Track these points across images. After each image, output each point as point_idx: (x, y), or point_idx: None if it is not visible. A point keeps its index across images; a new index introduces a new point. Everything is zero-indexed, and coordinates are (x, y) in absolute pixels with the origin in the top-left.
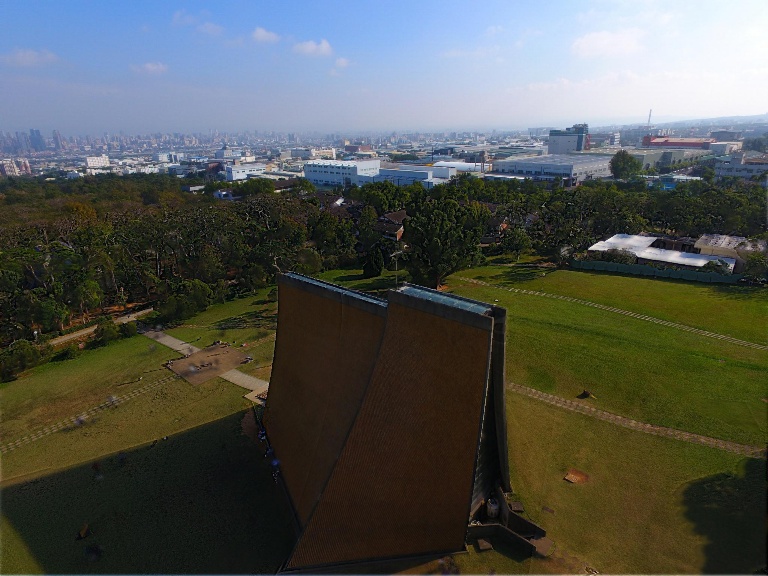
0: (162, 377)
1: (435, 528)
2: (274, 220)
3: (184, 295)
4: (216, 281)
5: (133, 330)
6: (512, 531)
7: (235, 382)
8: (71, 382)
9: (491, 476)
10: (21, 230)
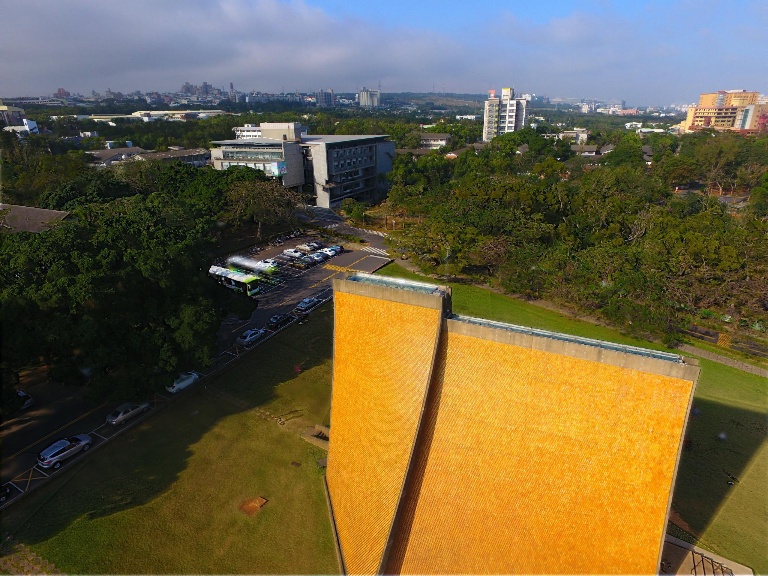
0: None
1: None
2: None
3: None
4: None
5: None
6: None
7: None
8: None
9: None
10: None
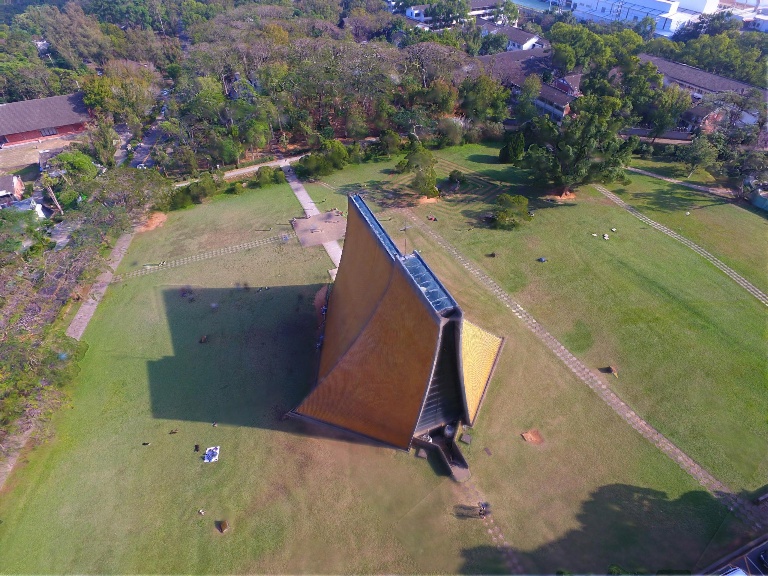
0: (285, 232)
1: (390, 430)
2: (431, 77)
3: (323, 155)
4: (359, 139)
5: (282, 178)
6: (444, 455)
7: (330, 254)
8: (230, 217)
9: (455, 411)
10: (227, 54)
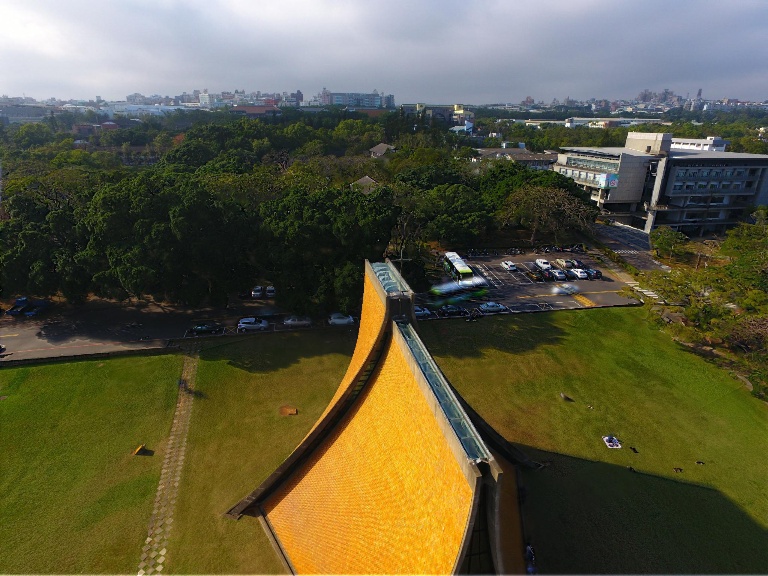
0: None
1: None
2: None
3: None
4: None
5: None
6: None
7: None
8: None
9: None
10: None
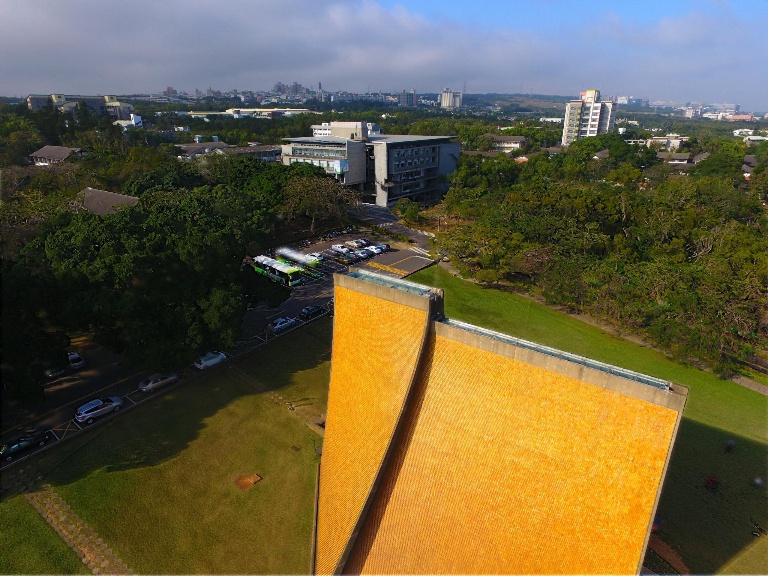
0: None
1: None
2: None
3: None
4: None
5: None
6: None
7: None
8: None
9: None
10: None
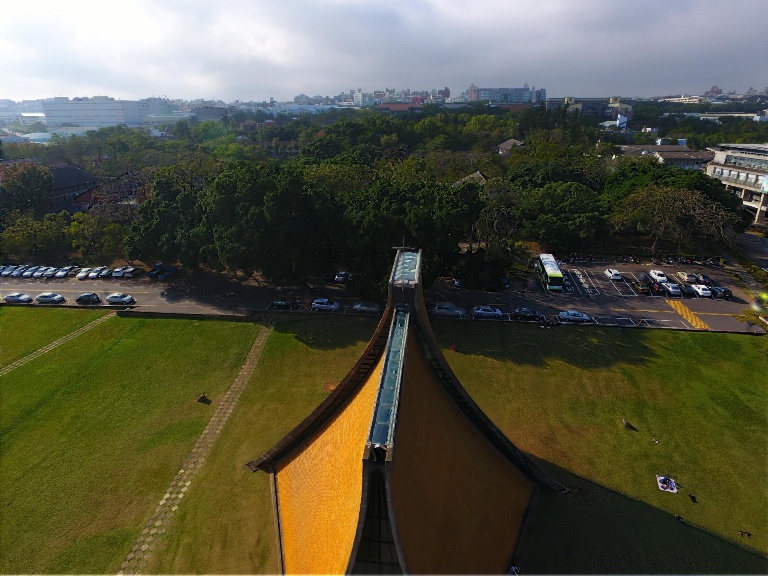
0: None
1: None
2: None
3: None
4: None
5: None
6: None
7: None
8: None
9: None
10: None
